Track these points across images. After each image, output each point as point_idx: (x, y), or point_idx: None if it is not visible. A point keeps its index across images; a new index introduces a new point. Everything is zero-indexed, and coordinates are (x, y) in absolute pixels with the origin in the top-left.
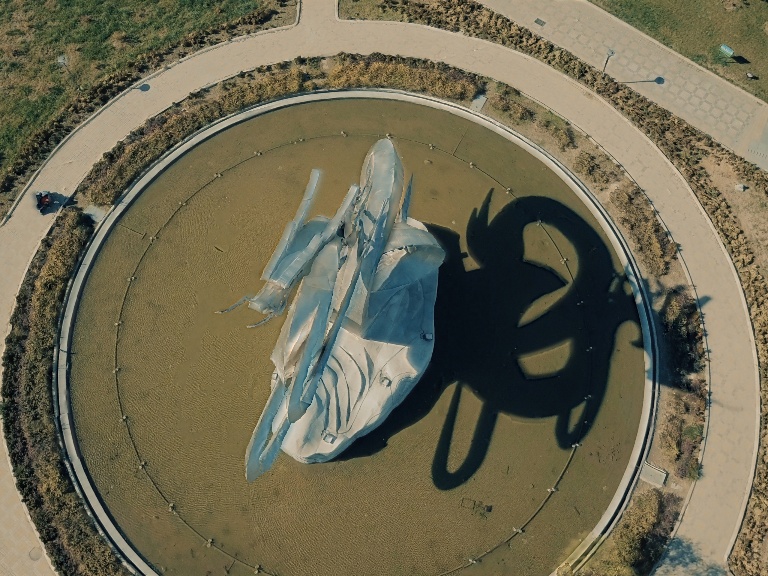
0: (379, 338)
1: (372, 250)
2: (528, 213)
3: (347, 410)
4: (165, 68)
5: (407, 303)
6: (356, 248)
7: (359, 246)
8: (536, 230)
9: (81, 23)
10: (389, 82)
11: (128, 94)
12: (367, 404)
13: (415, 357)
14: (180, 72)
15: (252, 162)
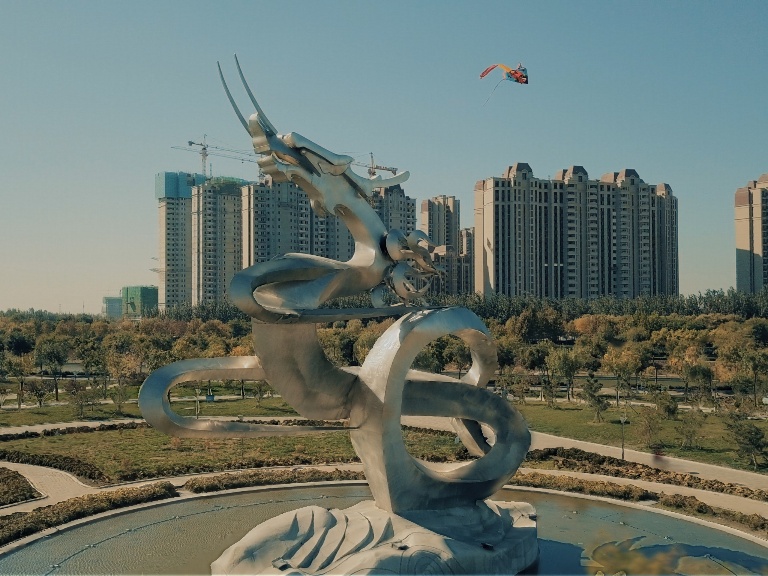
0: (416, 521)
1: (421, 317)
2: (691, 551)
3: (328, 558)
4: (326, 464)
5: (475, 528)
6: (405, 317)
7: (409, 316)
8: (700, 560)
9: (276, 446)
10: (543, 482)
11: (281, 468)
12: (360, 555)
13: (457, 544)
14: (338, 467)
15: (365, 498)
